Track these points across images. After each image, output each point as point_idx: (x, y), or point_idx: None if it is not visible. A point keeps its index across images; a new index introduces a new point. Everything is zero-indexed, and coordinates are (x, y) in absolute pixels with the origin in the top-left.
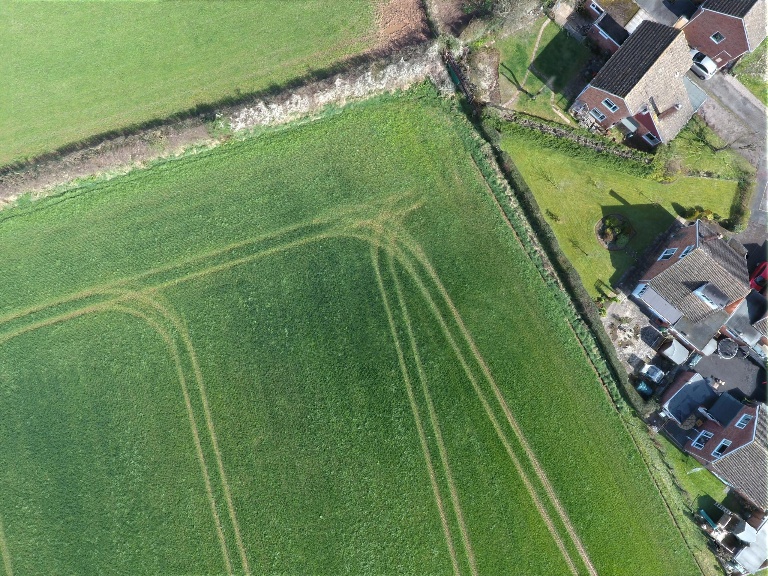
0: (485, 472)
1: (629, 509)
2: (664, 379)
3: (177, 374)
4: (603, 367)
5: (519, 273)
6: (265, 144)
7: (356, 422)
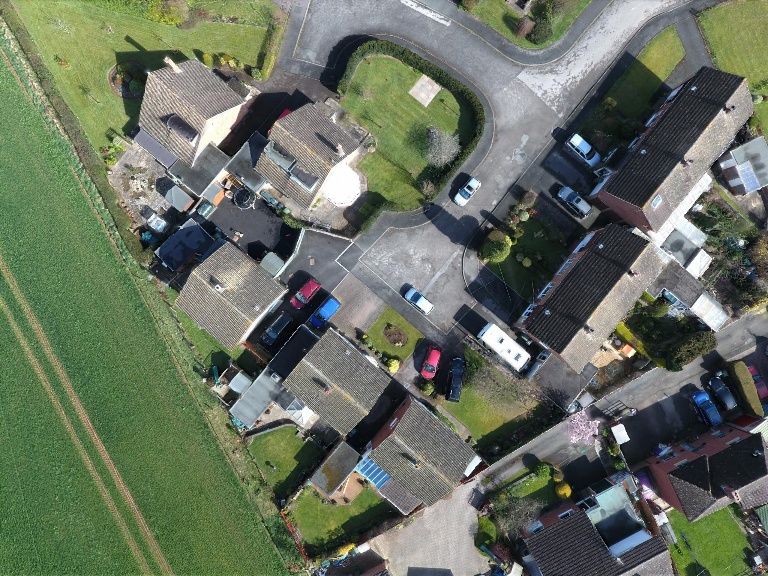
0: None
1: (135, 365)
2: None
3: None
4: (108, 217)
5: (20, 120)
6: None
7: None
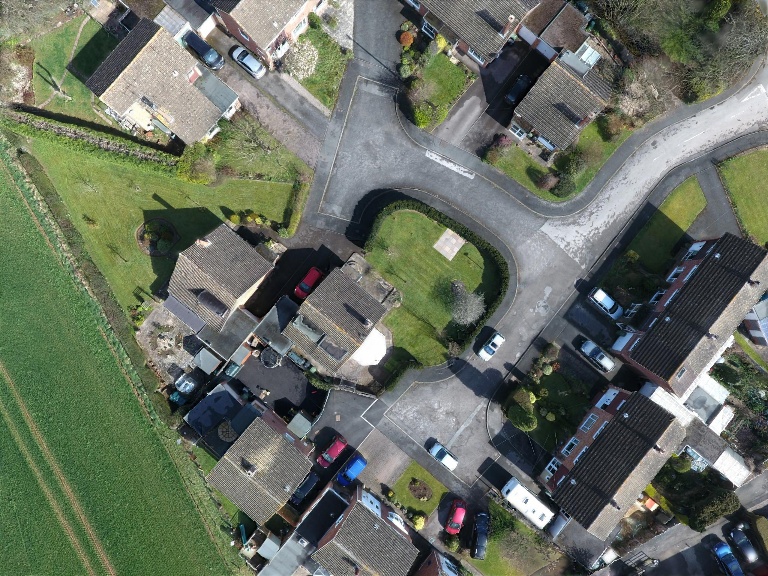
0: (2, 488)
1: (163, 525)
2: None
3: None
4: (136, 378)
5: (49, 281)
6: None
7: None
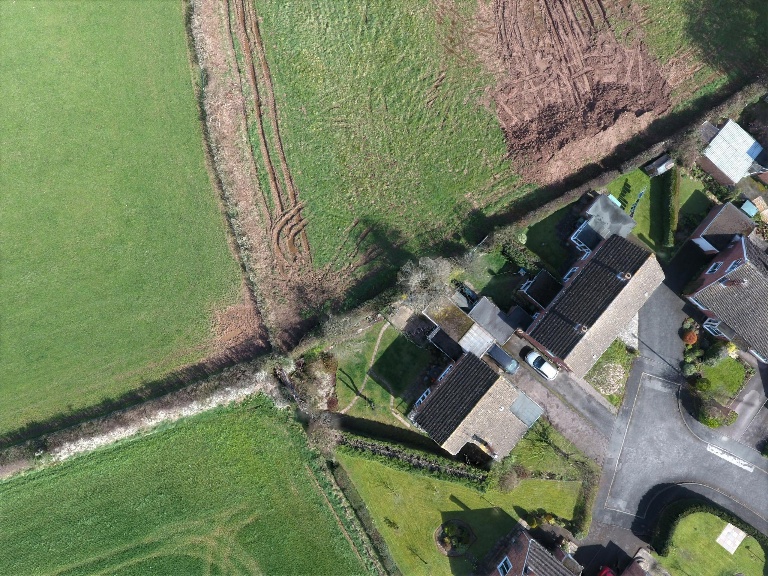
0: None
1: None
2: None
3: None
4: None
5: None
6: (96, 463)
7: None
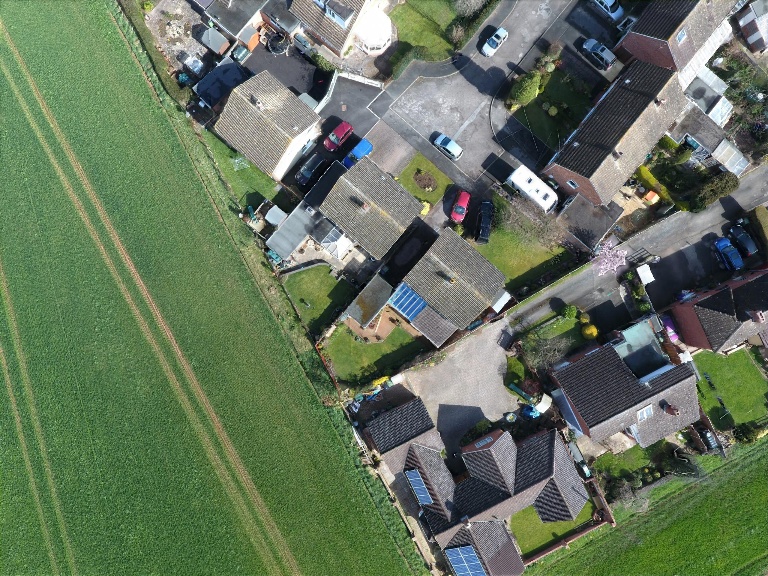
0: (13, 160)
1: (172, 204)
2: (208, 72)
3: None
4: (146, 60)
5: None
6: None
7: None
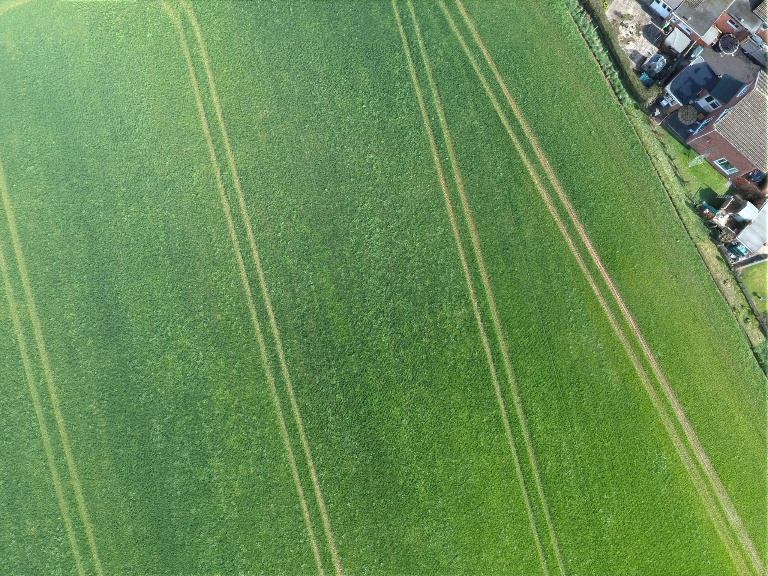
0: (489, 155)
1: (632, 199)
2: (666, 71)
3: (182, 47)
4: (605, 59)
5: None
6: None
7: (360, 101)
